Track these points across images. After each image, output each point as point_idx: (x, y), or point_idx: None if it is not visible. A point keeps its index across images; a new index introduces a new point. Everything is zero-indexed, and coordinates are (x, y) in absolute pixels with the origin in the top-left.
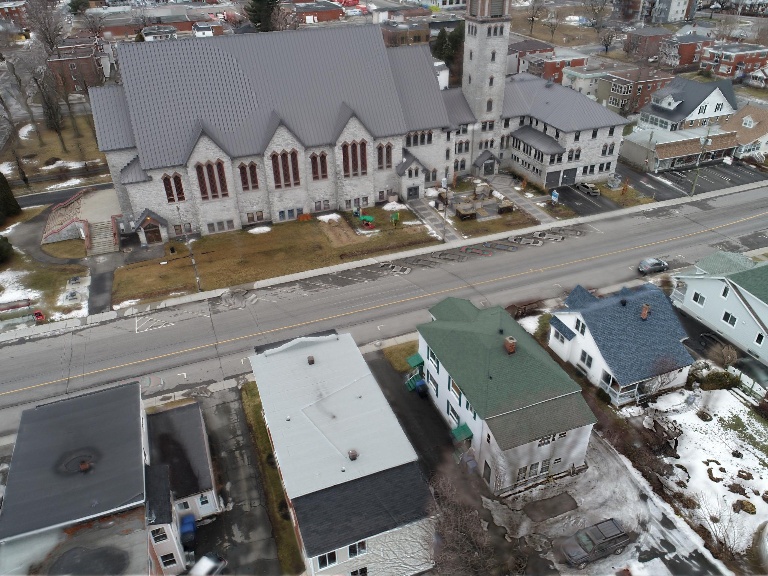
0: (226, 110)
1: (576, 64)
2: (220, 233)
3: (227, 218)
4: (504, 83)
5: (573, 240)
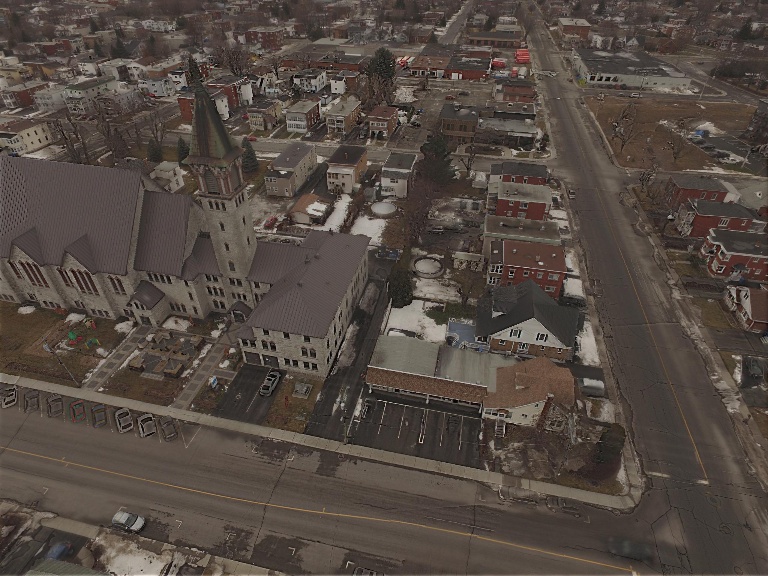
0: (4, 218)
1: (535, 207)
2: (6, 302)
3: (8, 294)
4: (241, 251)
5: (151, 442)
